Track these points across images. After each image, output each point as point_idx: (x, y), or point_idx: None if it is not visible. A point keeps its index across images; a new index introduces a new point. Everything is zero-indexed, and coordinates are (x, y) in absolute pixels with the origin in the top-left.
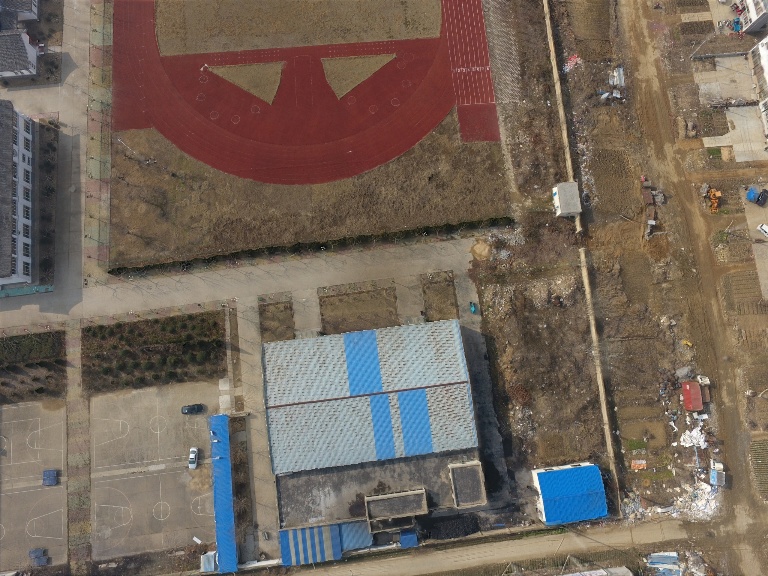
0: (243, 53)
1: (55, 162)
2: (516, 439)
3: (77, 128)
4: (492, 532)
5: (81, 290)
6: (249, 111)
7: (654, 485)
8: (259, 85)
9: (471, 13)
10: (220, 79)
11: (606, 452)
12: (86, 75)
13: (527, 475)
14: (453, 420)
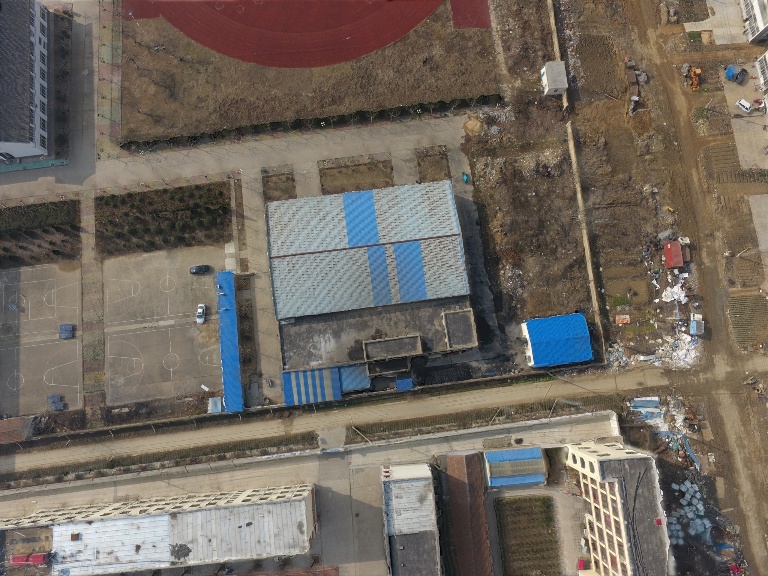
0: None
1: (69, 48)
2: (506, 295)
3: (90, 17)
4: (483, 378)
5: (94, 163)
6: (252, 2)
7: (637, 337)
8: None
9: None
10: None
11: (592, 308)
12: None
13: (517, 328)
14: (446, 270)
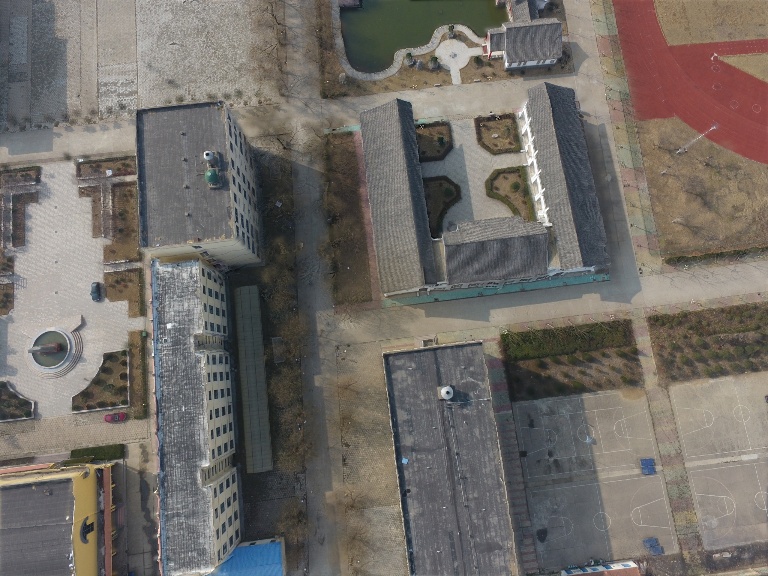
0: (750, 42)
1: None
2: None
3: (601, 117)
4: None
5: (638, 279)
6: None
7: None
8: None
9: None
10: (733, 68)
11: None
12: (598, 64)
13: None
14: None
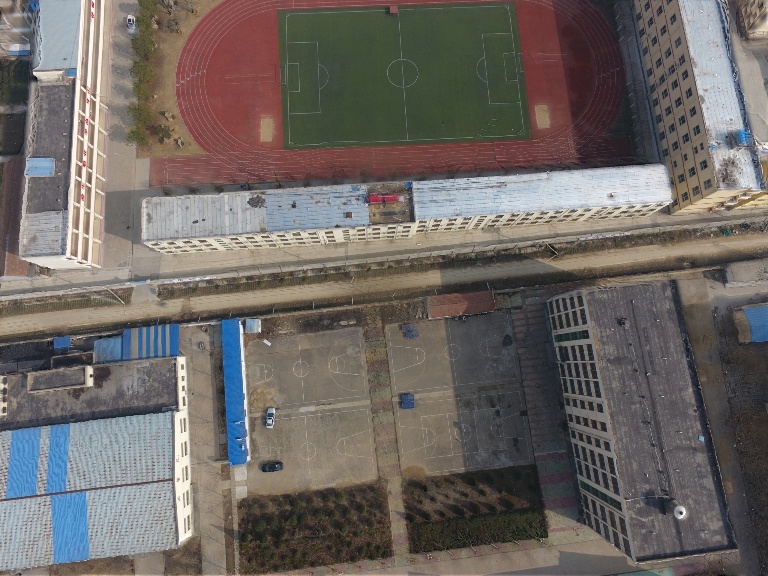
0: None
1: None
2: None
3: None
4: None
5: None
6: None
7: None
8: None
9: None
10: None
11: None
12: None
13: None
14: None
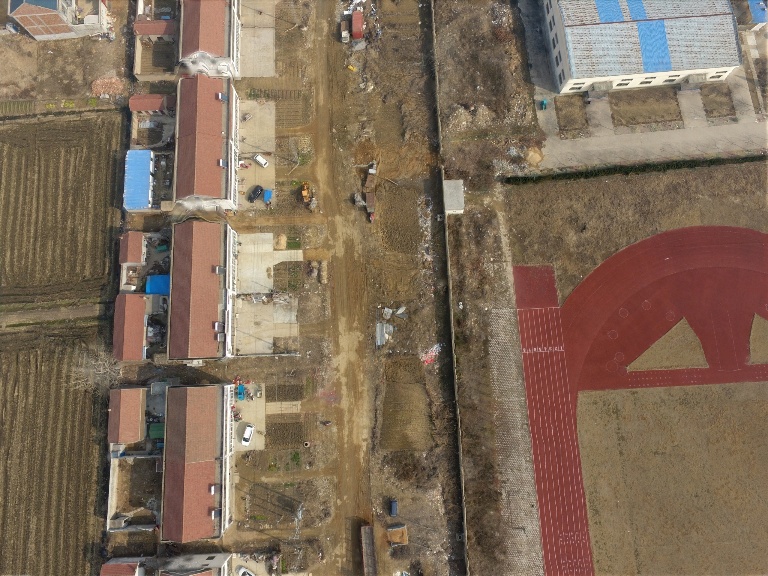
0: None
1: None
2: (508, 2)
3: None
4: None
5: None
6: None
7: None
8: None
9: (543, 422)
10: None
11: None
12: None
13: None
14: (575, 1)
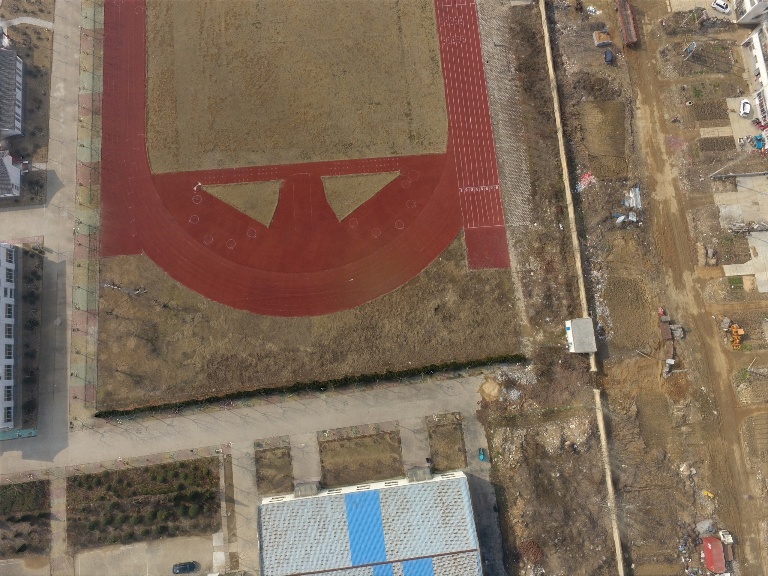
0: (239, 170)
1: (39, 292)
2: None
3: (63, 254)
4: None
5: (66, 434)
6: (245, 235)
7: None
8: (256, 206)
9: (479, 126)
10: (214, 199)
11: None
12: (73, 195)
13: None
14: None
